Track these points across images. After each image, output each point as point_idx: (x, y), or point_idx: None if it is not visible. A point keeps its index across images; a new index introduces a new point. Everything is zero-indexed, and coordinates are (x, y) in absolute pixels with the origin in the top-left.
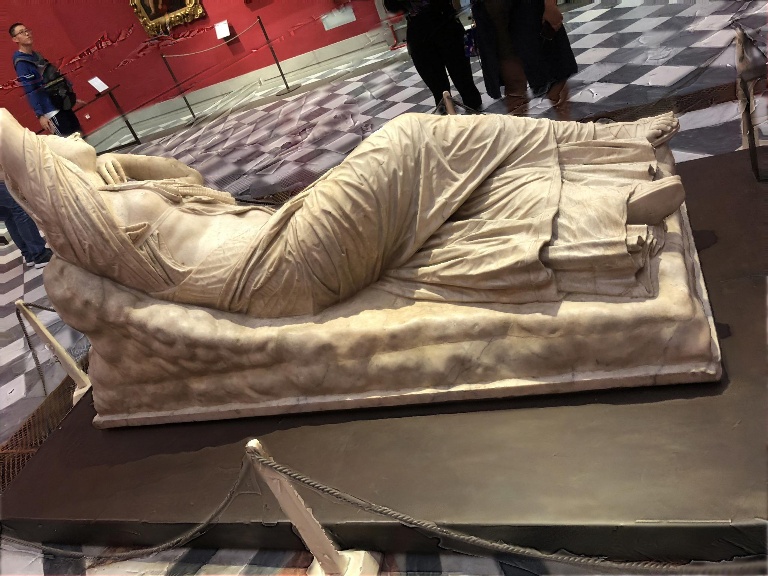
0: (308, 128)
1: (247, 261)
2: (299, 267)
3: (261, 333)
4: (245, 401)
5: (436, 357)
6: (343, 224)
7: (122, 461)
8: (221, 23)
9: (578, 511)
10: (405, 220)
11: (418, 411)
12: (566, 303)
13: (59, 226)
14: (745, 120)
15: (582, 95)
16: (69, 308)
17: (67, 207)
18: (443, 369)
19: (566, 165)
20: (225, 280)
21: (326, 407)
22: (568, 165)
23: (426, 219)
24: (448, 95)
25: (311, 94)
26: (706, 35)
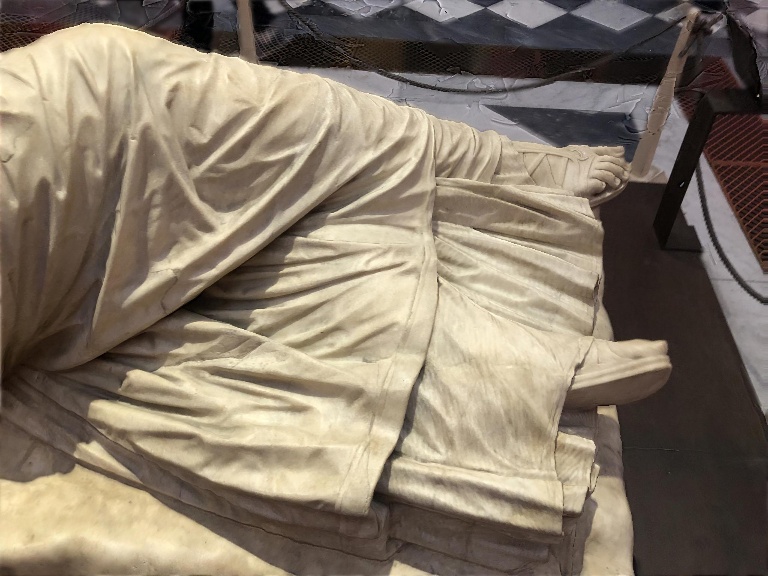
0: None
1: None
2: None
3: None
4: None
5: None
6: None
7: None
8: None
9: None
10: (69, 291)
11: None
12: (400, 570)
13: None
14: (680, 161)
15: (426, 5)
16: None
17: None
18: None
19: (441, 222)
20: None
21: None
22: (445, 223)
23: (120, 308)
24: None
25: None
26: None
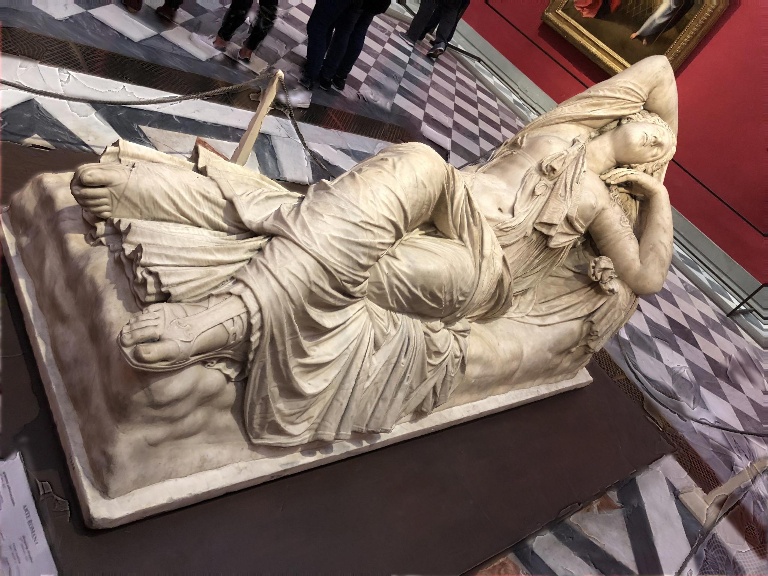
0: None
1: None
2: None
3: None
4: None
5: None
6: None
7: None
8: None
9: (91, 159)
10: None
11: None
12: None
13: None
14: None
15: None
16: None
17: None
18: None
19: None
20: None
21: None
22: None
23: None
24: None
25: None
26: None
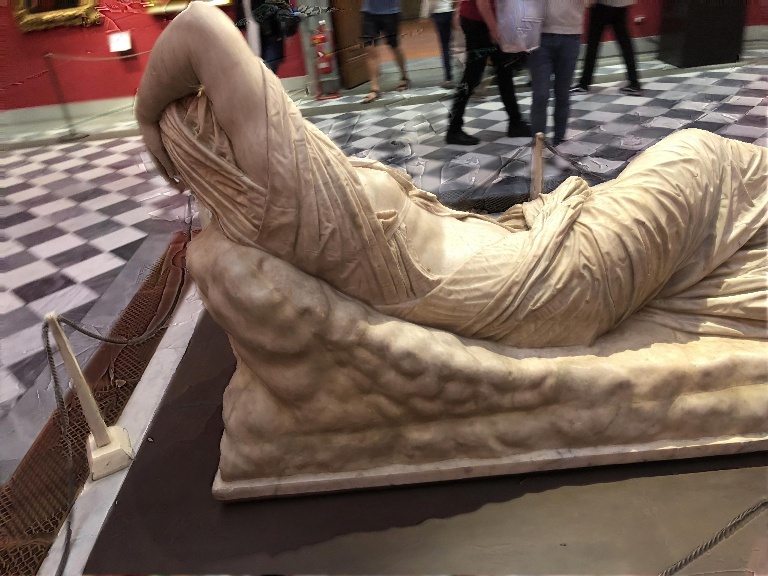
0: (365, 149)
1: (528, 273)
2: (596, 285)
3: (535, 365)
4: (479, 455)
5: (755, 399)
6: (656, 238)
7: (290, 545)
8: (336, 8)
9: None
10: (695, 243)
11: (717, 464)
12: None
13: (296, 198)
14: None
15: (588, 165)
16: (272, 317)
17: (315, 172)
18: (762, 413)
19: None
20: (493, 295)
21: (597, 461)
22: None
23: (726, 244)
24: (541, 136)
25: (365, 114)
26: (666, 131)
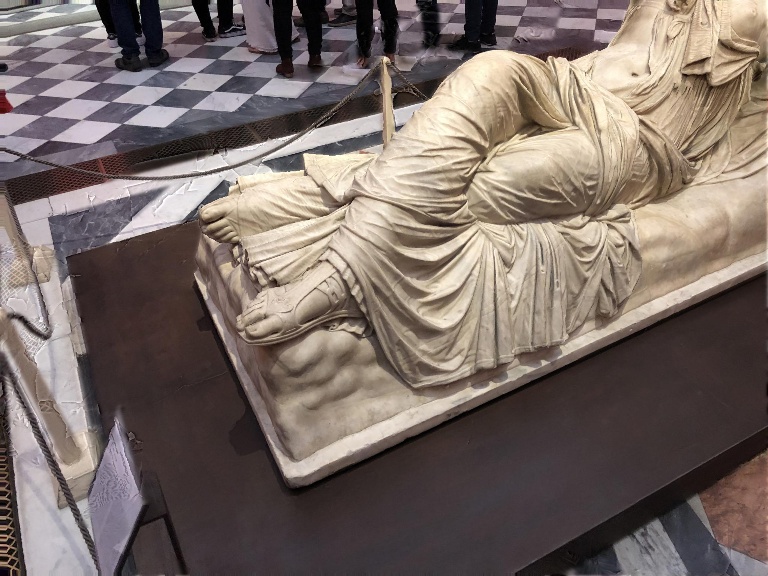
0: None
1: None
2: None
3: None
4: None
5: None
6: None
7: None
8: None
9: None
10: None
11: None
12: None
13: None
14: None
15: None
16: None
17: None
18: None
19: None
20: None
21: None
22: None
23: None
24: None
25: None
26: None
